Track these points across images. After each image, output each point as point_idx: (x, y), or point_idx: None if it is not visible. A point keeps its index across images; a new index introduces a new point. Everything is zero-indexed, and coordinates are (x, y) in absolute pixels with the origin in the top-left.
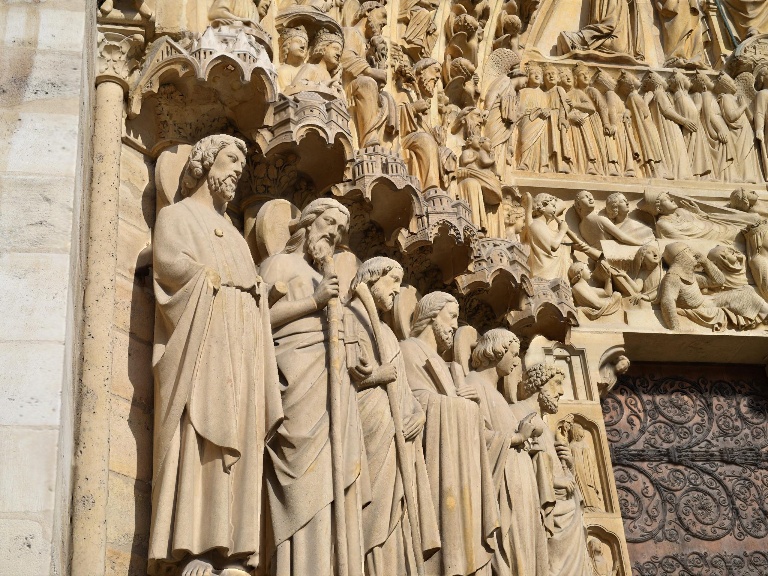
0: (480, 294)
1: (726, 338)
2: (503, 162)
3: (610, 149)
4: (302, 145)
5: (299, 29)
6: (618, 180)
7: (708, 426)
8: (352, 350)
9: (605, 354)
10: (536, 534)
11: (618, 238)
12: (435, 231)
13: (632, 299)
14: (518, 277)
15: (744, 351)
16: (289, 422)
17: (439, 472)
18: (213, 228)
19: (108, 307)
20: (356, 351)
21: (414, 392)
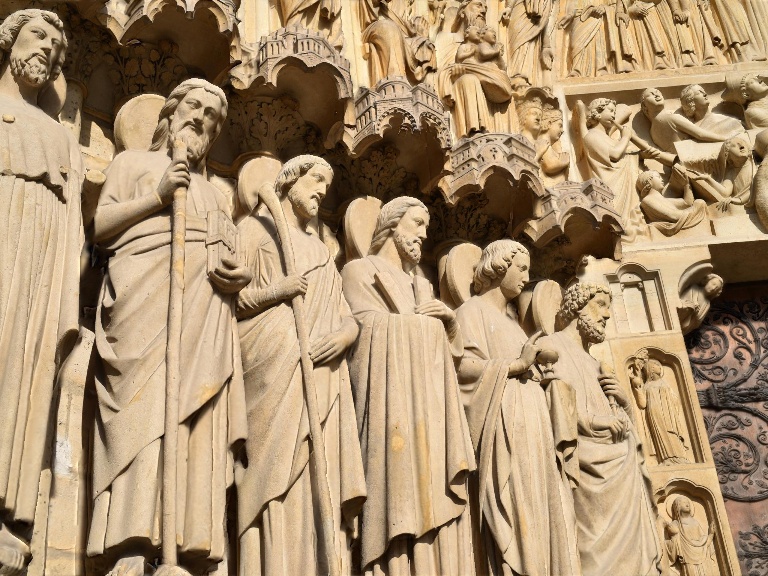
0: (486, 207)
1: None
2: (532, 63)
3: (682, 38)
4: (161, 22)
5: None
6: (694, 71)
7: None
8: (214, 252)
9: (686, 273)
10: (548, 482)
11: (695, 136)
12: (384, 122)
13: (719, 205)
14: (516, 173)
15: None
16: (117, 344)
17: (385, 407)
18: (3, 114)
19: None
20: (218, 252)
21: (358, 315)
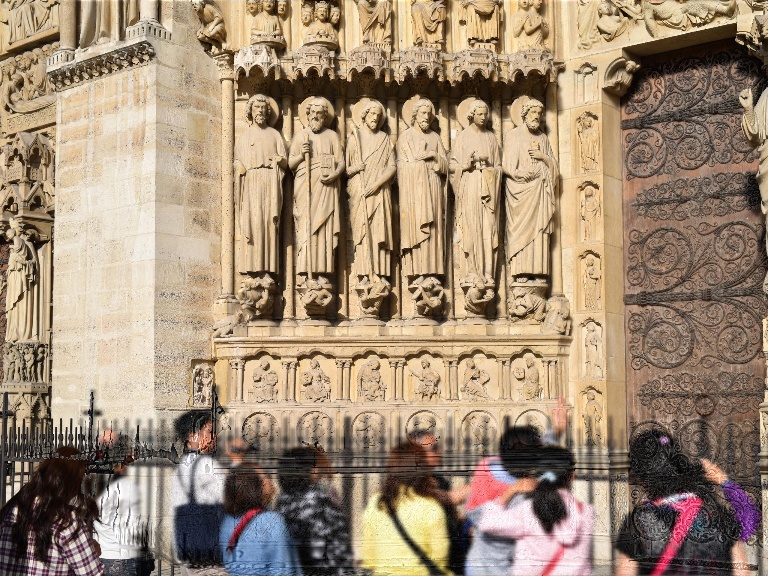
0: None
1: (693, 33)
2: None
3: None
4: (301, 76)
5: (305, 7)
6: None
7: (705, 89)
8: None
9: (611, 66)
10: None
11: None
12: (404, 74)
13: (634, 20)
14: (471, 74)
15: (721, 33)
16: None
17: None
18: None
19: (227, 182)
20: (322, 172)
21: None
